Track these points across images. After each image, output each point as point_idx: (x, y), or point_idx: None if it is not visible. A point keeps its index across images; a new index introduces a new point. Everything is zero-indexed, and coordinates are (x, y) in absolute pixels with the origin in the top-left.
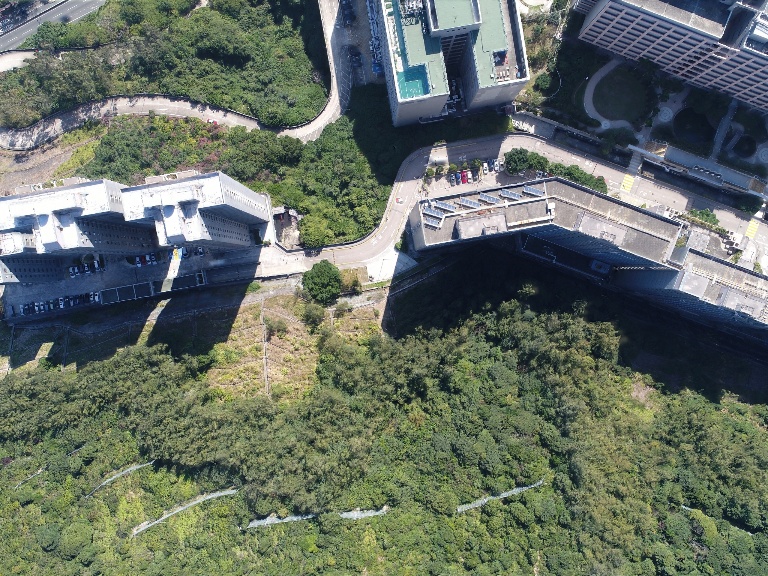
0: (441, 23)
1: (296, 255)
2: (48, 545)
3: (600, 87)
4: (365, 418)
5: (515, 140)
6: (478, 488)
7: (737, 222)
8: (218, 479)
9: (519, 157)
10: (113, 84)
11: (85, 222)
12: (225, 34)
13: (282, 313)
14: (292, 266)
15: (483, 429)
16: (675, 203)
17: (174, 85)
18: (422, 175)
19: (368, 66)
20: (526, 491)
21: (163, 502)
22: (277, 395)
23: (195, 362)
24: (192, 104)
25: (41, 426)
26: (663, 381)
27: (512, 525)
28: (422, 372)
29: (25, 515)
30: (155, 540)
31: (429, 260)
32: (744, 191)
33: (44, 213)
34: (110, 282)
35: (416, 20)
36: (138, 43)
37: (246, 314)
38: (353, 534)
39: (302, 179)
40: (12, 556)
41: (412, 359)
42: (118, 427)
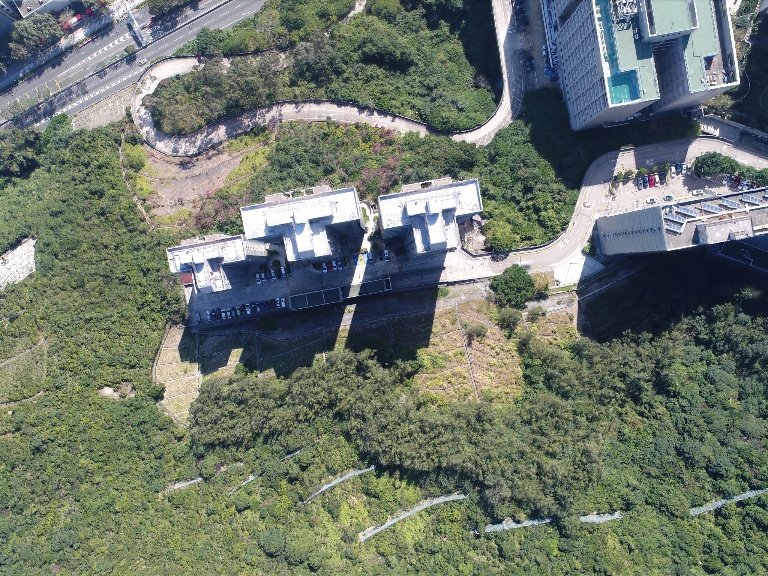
0: (658, 28)
1: (482, 260)
2: (276, 551)
3: None
4: (589, 422)
5: (702, 143)
6: (709, 491)
7: None
8: (447, 484)
9: (713, 161)
10: (279, 90)
11: (327, 230)
12: (390, 39)
13: (477, 318)
14: (478, 271)
15: (707, 432)
16: None
17: (343, 91)
18: (609, 179)
19: (540, 70)
20: (763, 494)
21: (389, 507)
22: (490, 400)
23: (410, 367)
24: (359, 109)
25: (255, 432)
26: None
27: (752, 528)
28: (643, 376)
29: (243, 521)
30: (386, 545)
31: (616, 264)
32: None
33: (303, 221)
34: (296, 288)
35: (627, 25)
36: (309, 49)
37: (443, 319)
38: (597, 538)
39: (481, 184)
40: (234, 562)
41: (625, 363)
42: (333, 433)
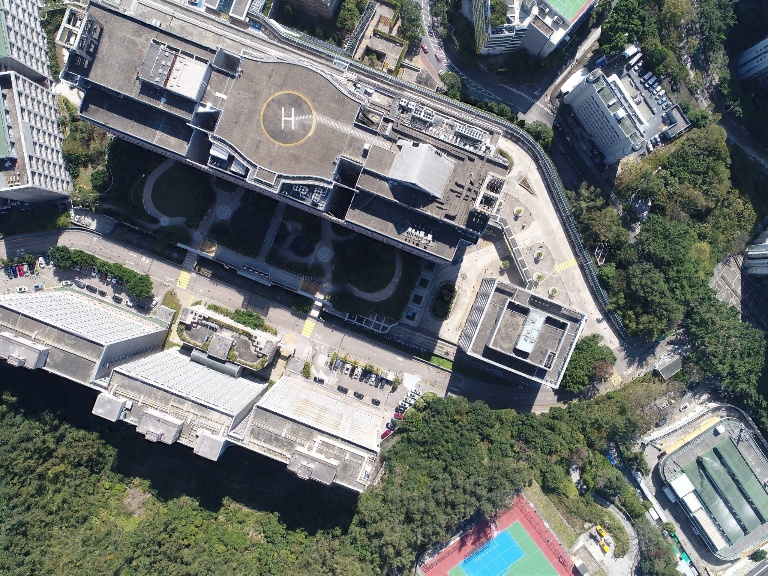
0: None
1: None
2: None
3: (159, 184)
4: None
5: (72, 235)
6: None
7: (293, 320)
8: None
9: (60, 255)
10: None
11: None
12: None
13: None
14: None
15: None
16: (231, 300)
17: None
18: None
19: None
20: None
21: None
22: None
23: None
24: None
25: None
26: (158, 488)
27: None
28: None
29: None
30: None
31: None
32: (293, 291)
33: None
34: None
35: None
36: None
37: None
38: None
39: None
40: None
41: None
42: None
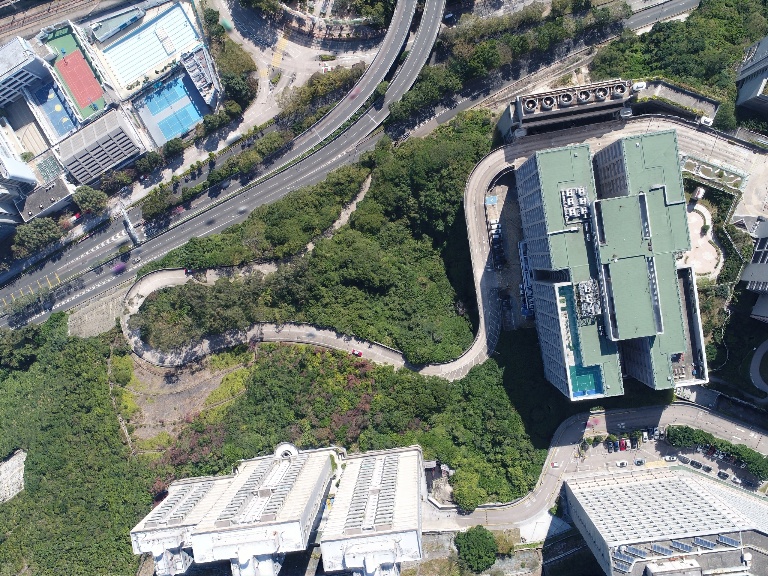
0: (622, 333)
1: (448, 512)
2: None
3: (767, 357)
4: None
5: (677, 409)
6: None
7: None
8: None
9: (684, 436)
10: (260, 310)
11: None
12: (370, 262)
13: None
14: (444, 522)
15: None
16: None
17: (321, 317)
18: (579, 441)
19: (517, 309)
20: None
21: None
22: None
23: None
24: (337, 334)
25: None
26: None
27: None
28: None
29: None
30: None
31: None
32: None
33: (247, 560)
34: None
35: (592, 321)
36: (288, 278)
37: None
38: None
39: (452, 428)
40: None
41: None
42: None
